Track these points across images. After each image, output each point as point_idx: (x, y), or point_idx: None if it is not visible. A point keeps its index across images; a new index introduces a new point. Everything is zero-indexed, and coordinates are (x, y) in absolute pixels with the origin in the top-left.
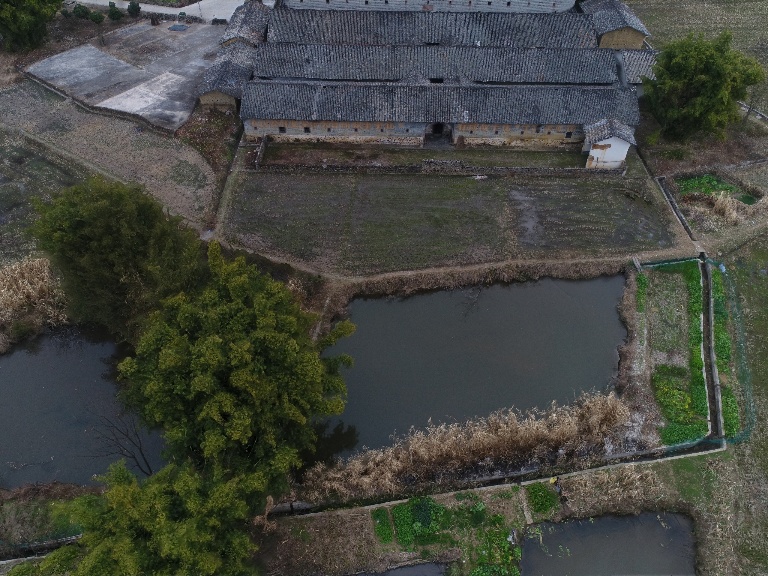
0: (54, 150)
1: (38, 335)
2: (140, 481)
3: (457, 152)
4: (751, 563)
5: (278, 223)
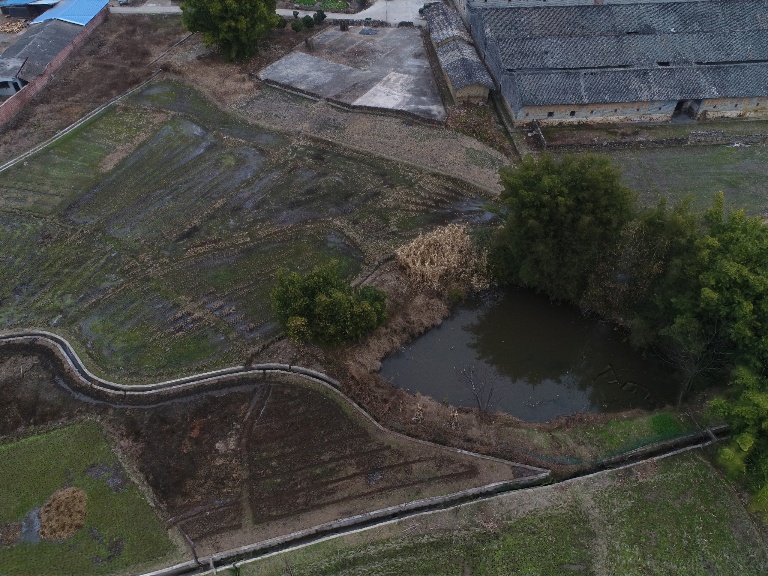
0: (346, 146)
1: (465, 300)
2: (762, 382)
3: (702, 125)
4: None
5: None
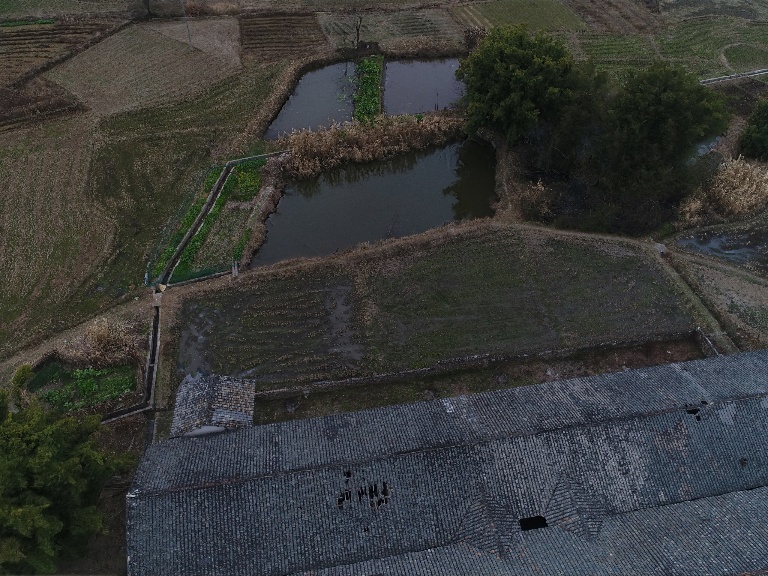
0: None
1: None
2: None
3: None
4: (241, 127)
5: (607, 272)
